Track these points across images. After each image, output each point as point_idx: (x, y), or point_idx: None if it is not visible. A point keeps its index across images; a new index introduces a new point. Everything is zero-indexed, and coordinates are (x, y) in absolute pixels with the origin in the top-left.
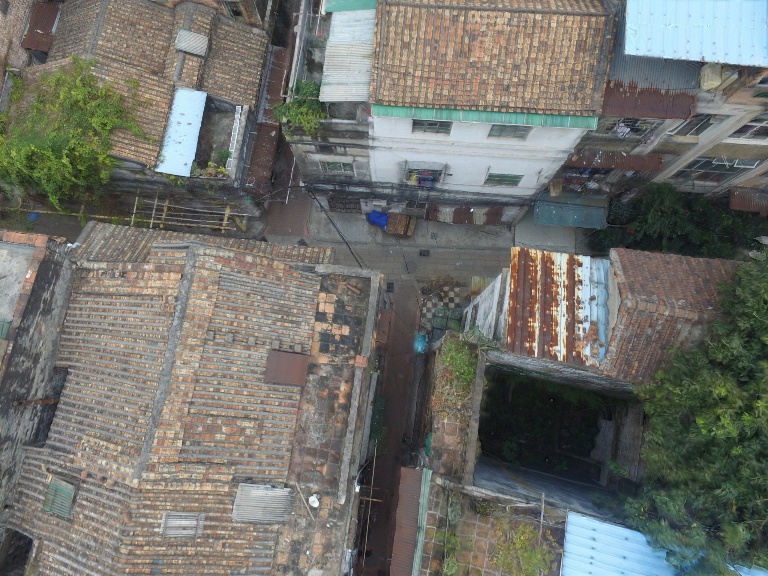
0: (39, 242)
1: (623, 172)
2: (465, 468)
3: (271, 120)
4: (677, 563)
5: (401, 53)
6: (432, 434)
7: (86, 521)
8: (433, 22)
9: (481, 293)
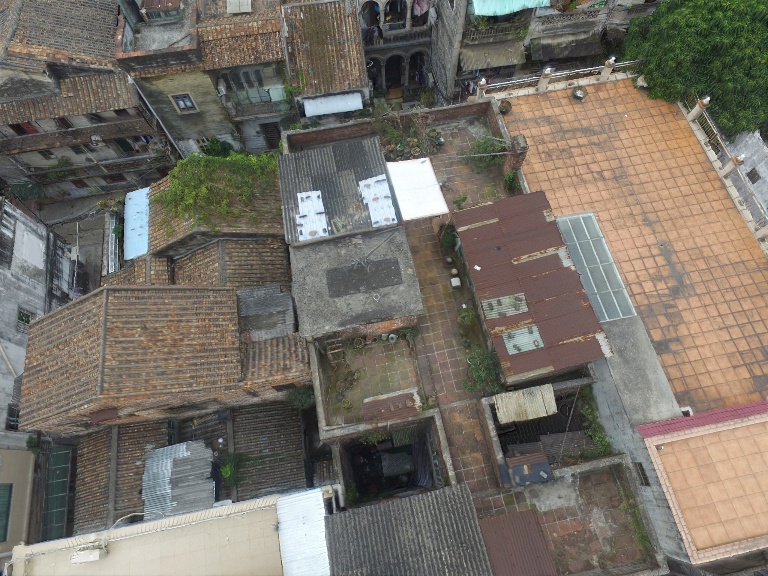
0: (121, 55)
1: None
2: None
3: None
4: None
5: None
6: None
7: None
8: None
9: None
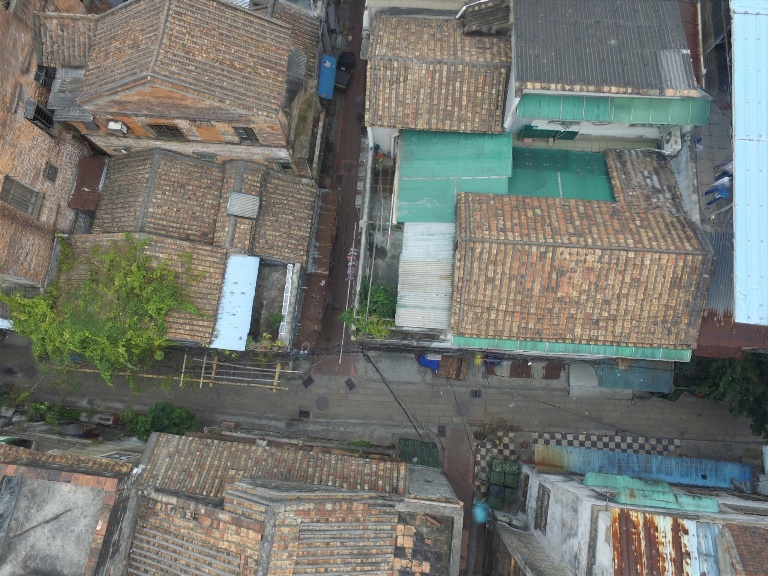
0: (108, 486)
1: None
2: None
3: (320, 269)
4: None
5: (485, 288)
6: None
7: None
8: (519, 258)
9: (552, 483)
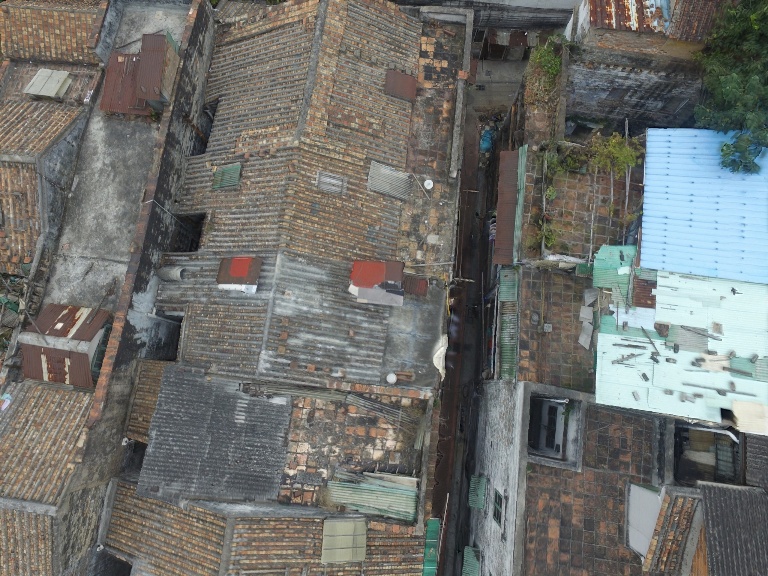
0: None
1: None
2: (555, 138)
3: None
4: None
5: None
6: (525, 121)
7: (253, 185)
8: None
9: None
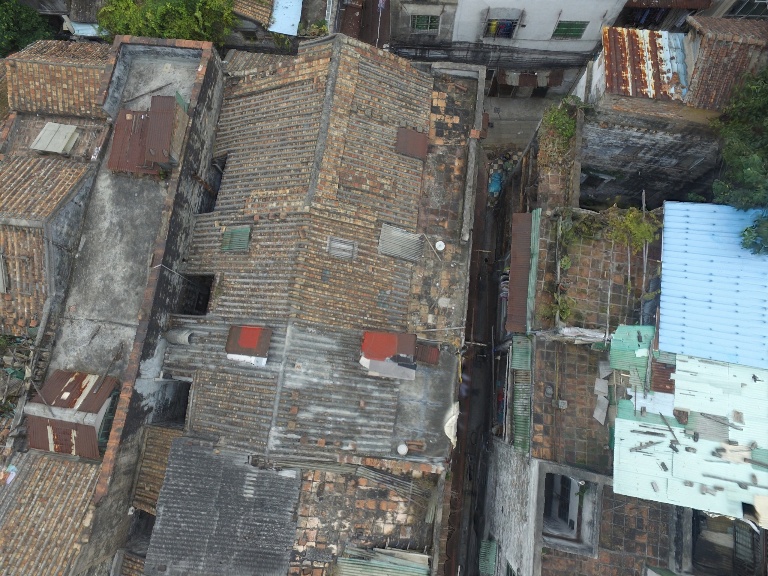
0: (205, 46)
1: (674, 23)
2: (570, 203)
3: (355, 2)
4: (758, 217)
5: None
6: (539, 184)
7: (262, 249)
8: None
9: None
